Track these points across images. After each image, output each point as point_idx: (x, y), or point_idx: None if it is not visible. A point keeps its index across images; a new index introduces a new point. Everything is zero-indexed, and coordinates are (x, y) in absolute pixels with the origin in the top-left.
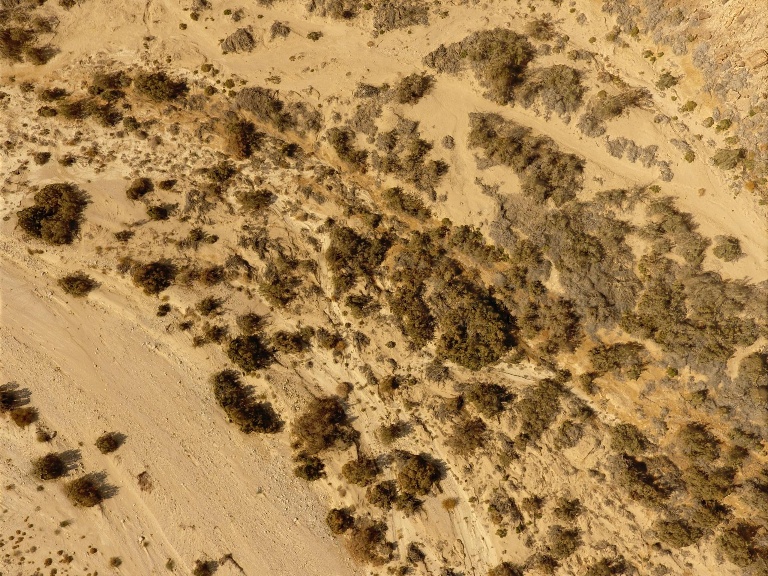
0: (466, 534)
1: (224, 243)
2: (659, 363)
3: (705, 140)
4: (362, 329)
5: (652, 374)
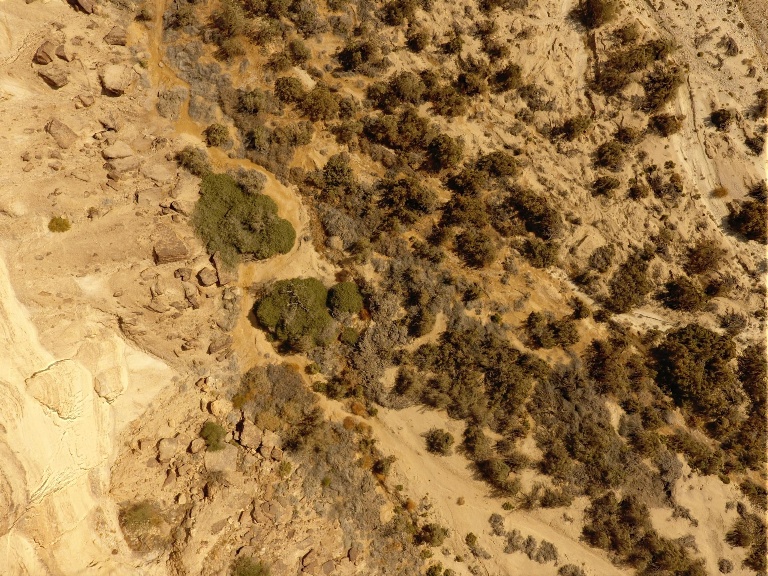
0: (702, 164)
1: None
2: (510, 328)
3: (452, 556)
4: None
5: (516, 317)
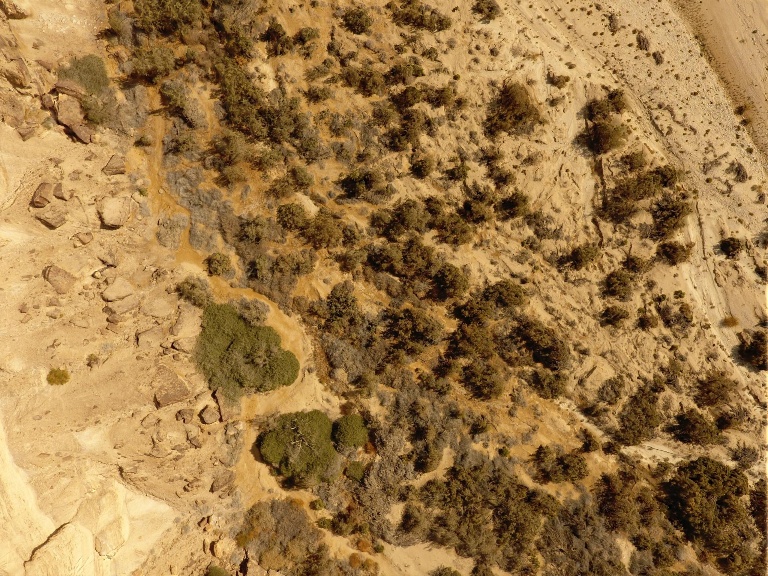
0: (712, 292)
1: None
2: (518, 462)
3: None
4: None
5: (525, 451)
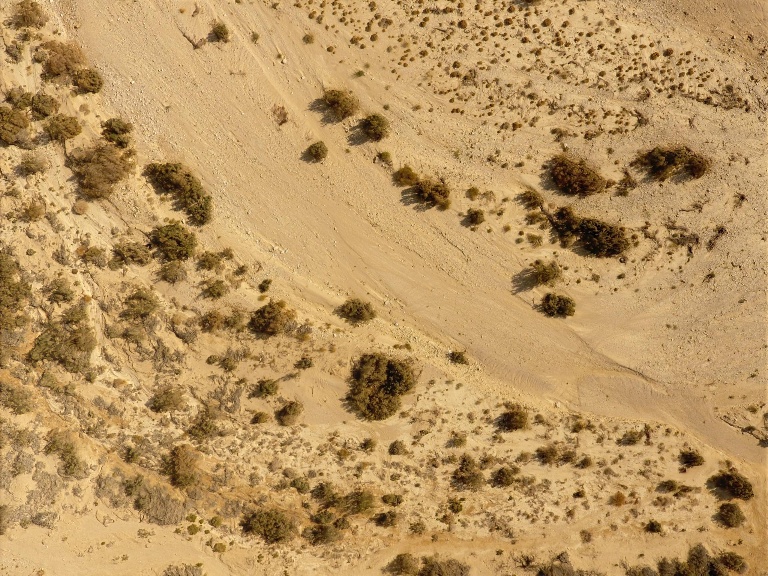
0: None
1: (200, 356)
2: None
3: None
4: (60, 268)
5: None
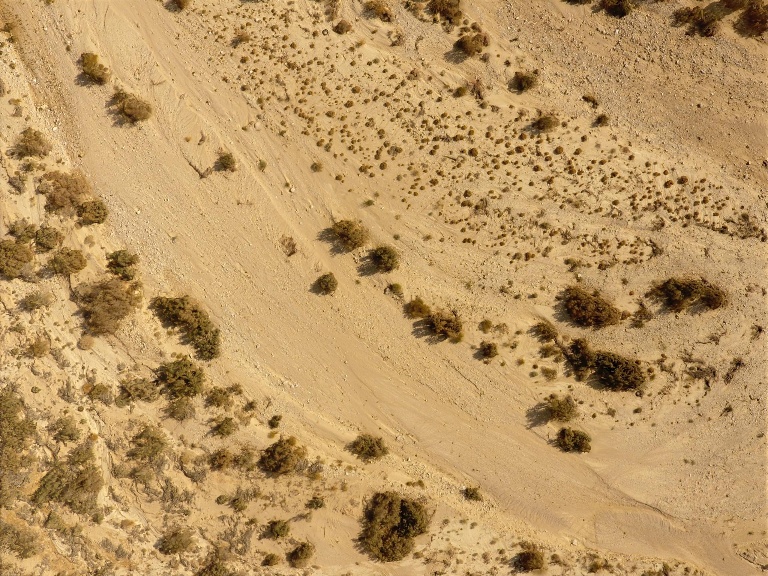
0: None
1: (209, 496)
2: None
3: None
4: (66, 405)
5: None
